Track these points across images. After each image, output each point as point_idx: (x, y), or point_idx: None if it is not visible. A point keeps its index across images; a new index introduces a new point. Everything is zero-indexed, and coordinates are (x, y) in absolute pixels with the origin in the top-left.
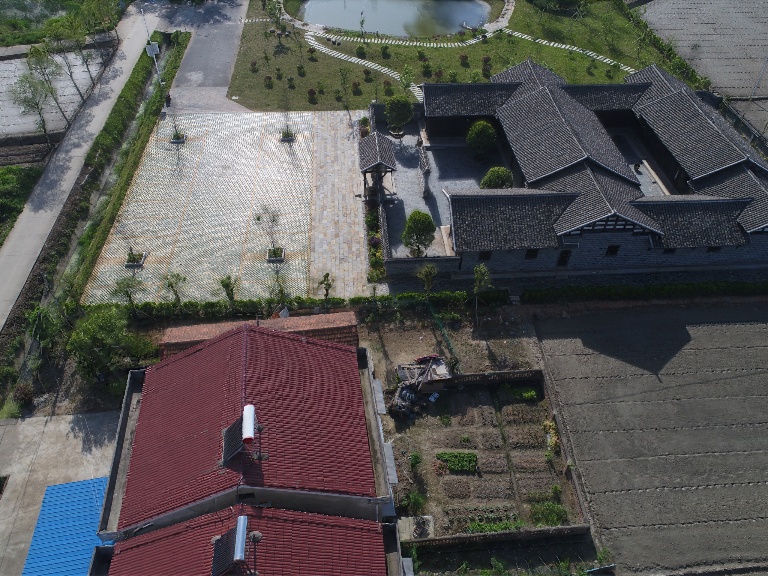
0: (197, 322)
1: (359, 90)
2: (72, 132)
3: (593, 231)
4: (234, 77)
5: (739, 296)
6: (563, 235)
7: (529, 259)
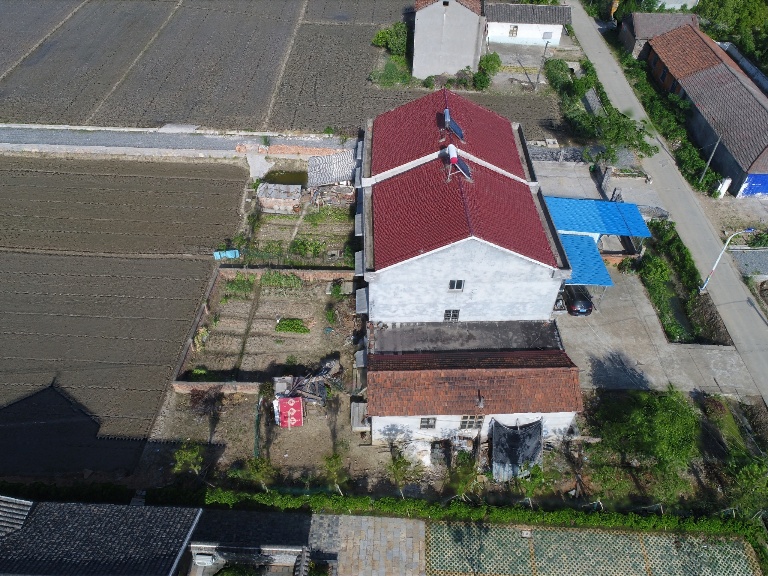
0: (572, 504)
1: None
2: None
3: None
4: None
5: None
6: None
7: None
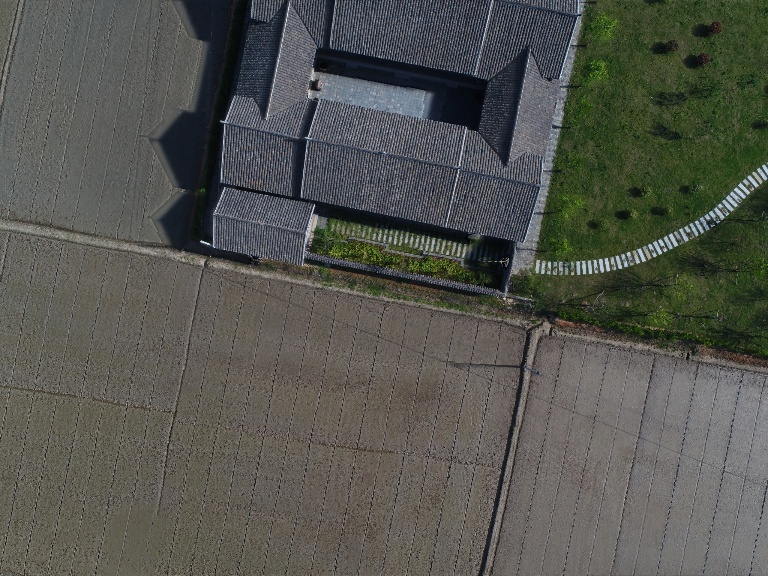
0: None
1: None
2: None
3: None
4: None
5: None
6: None
7: None
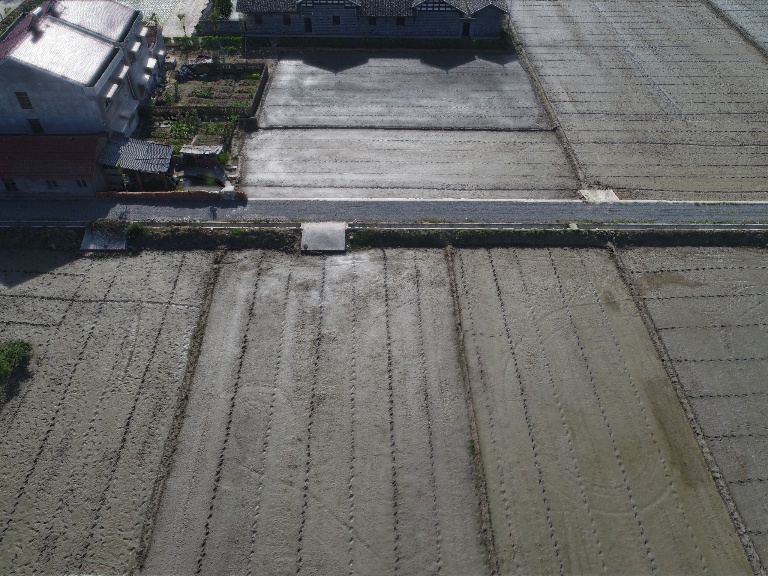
0: None
1: None
2: None
3: (320, 4)
4: None
5: (410, 48)
6: (302, 6)
7: (287, 24)
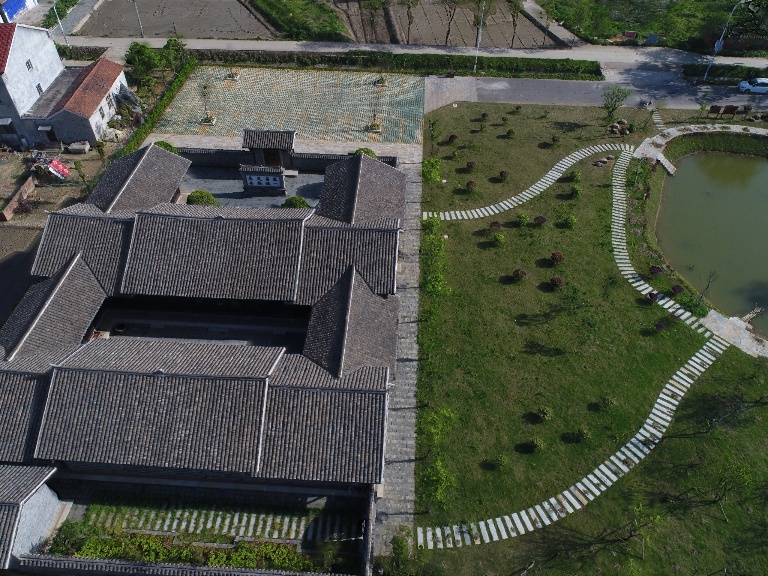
0: None
1: (468, 172)
2: (393, 44)
3: None
4: (499, 104)
5: None
6: None
7: None
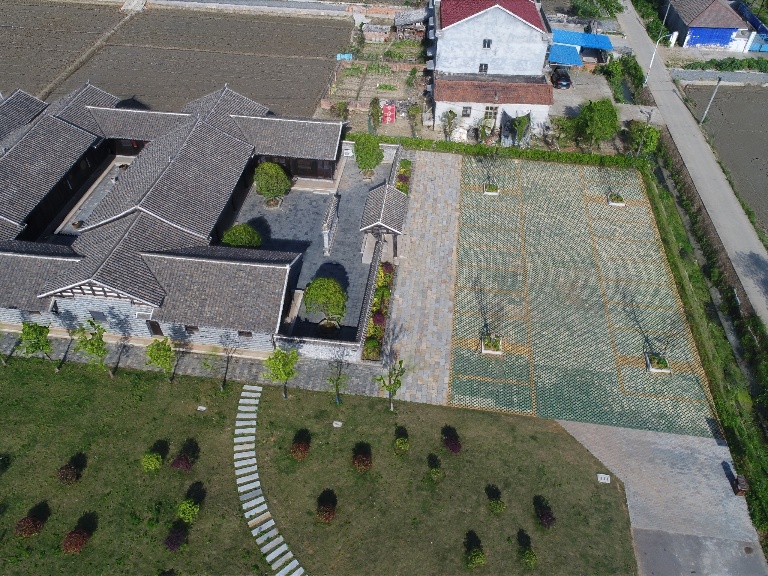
0: None
1: None
2: None
3: None
4: (633, 574)
5: None
6: None
7: None
